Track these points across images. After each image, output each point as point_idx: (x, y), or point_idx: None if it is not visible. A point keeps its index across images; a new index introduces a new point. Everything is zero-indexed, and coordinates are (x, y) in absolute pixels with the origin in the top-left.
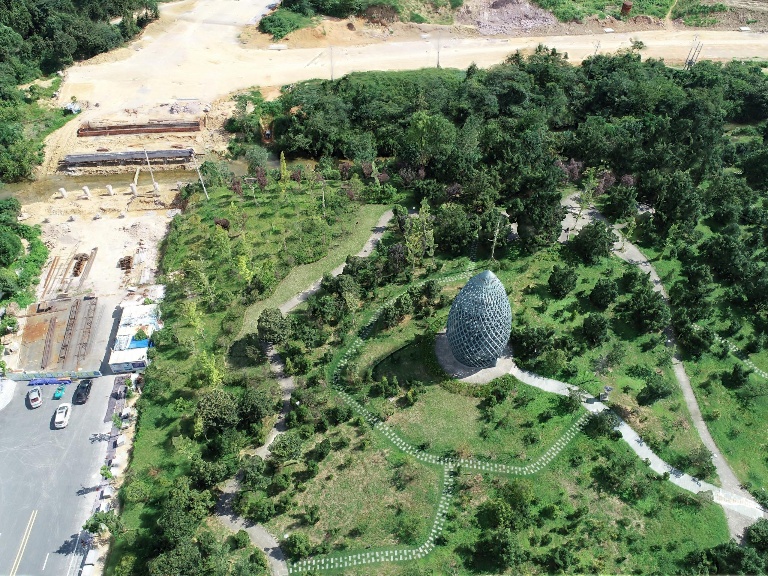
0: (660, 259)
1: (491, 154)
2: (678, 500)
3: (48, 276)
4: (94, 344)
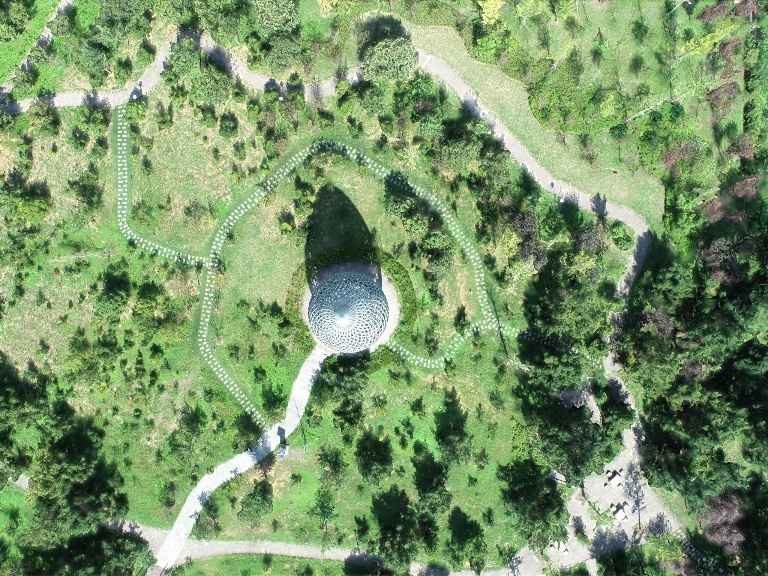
0: None
1: (767, 402)
2: (171, 487)
3: None
4: None
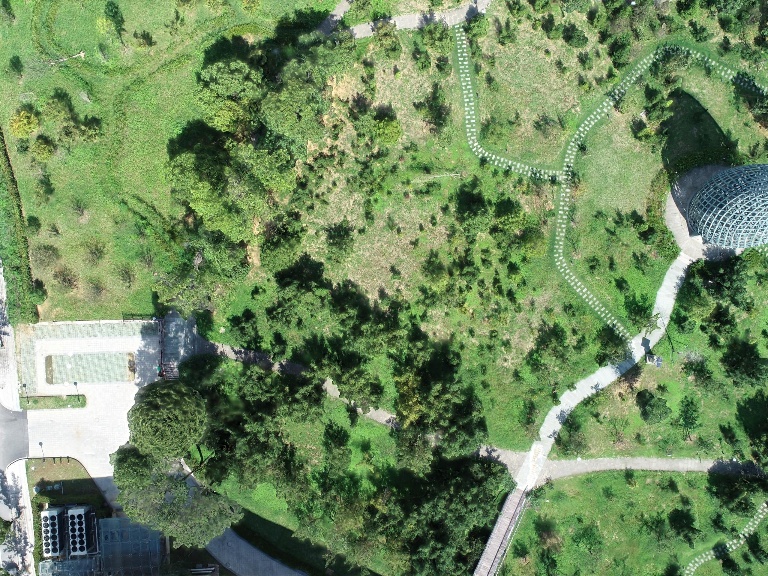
0: None
1: None
2: (532, 407)
3: None
4: None
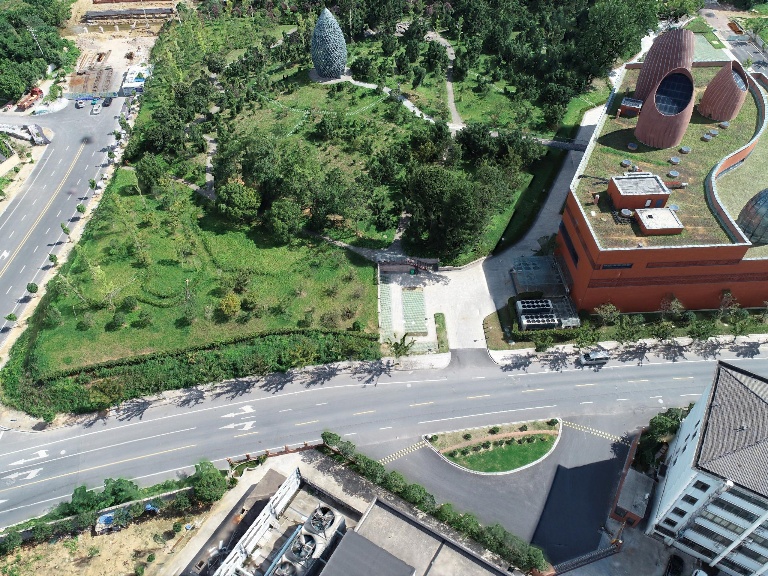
0: (458, 44)
1: None
2: (425, 124)
3: (82, 62)
4: (112, 86)
